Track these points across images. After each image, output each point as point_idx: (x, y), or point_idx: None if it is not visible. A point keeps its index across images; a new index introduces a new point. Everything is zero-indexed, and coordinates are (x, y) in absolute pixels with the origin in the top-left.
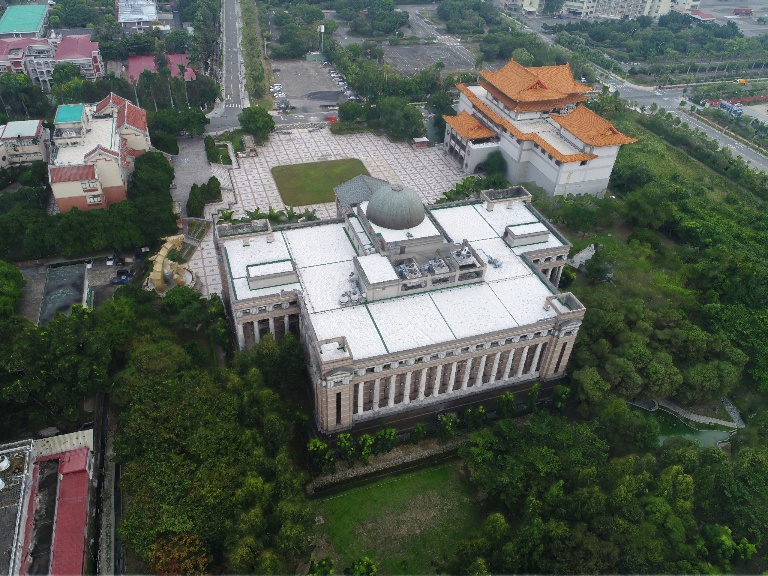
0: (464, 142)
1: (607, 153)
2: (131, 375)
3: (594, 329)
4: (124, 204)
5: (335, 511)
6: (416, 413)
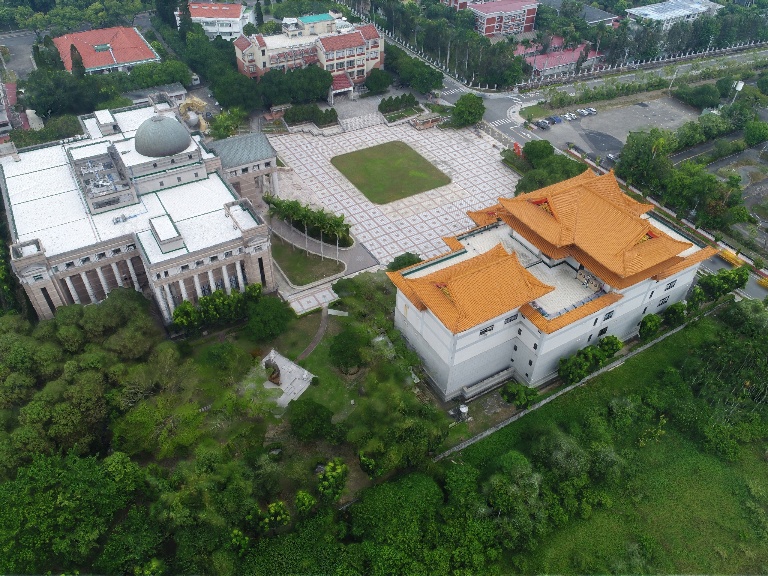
0: None
1: None
2: (54, 120)
3: None
4: None
5: None
6: None
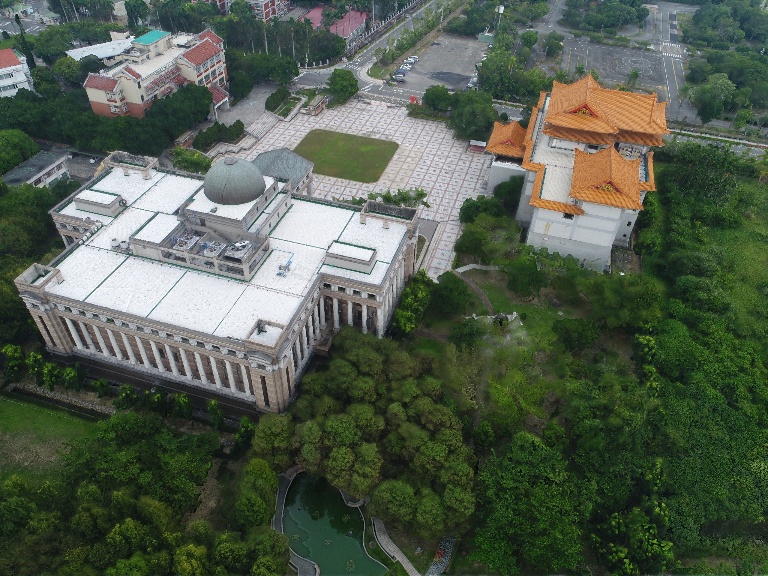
0: None
1: (605, 214)
2: None
3: (330, 383)
4: (124, 118)
5: (3, 412)
6: (133, 374)
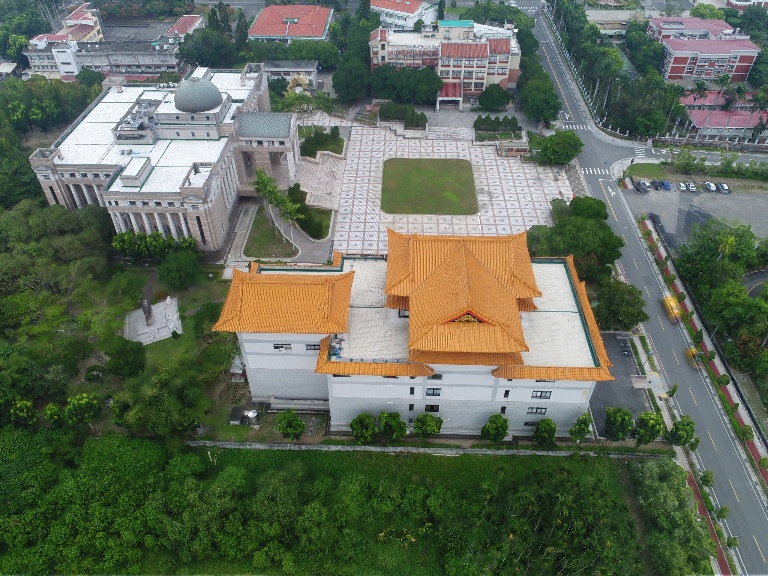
0: None
1: None
2: None
3: None
4: (355, 64)
5: None
6: None
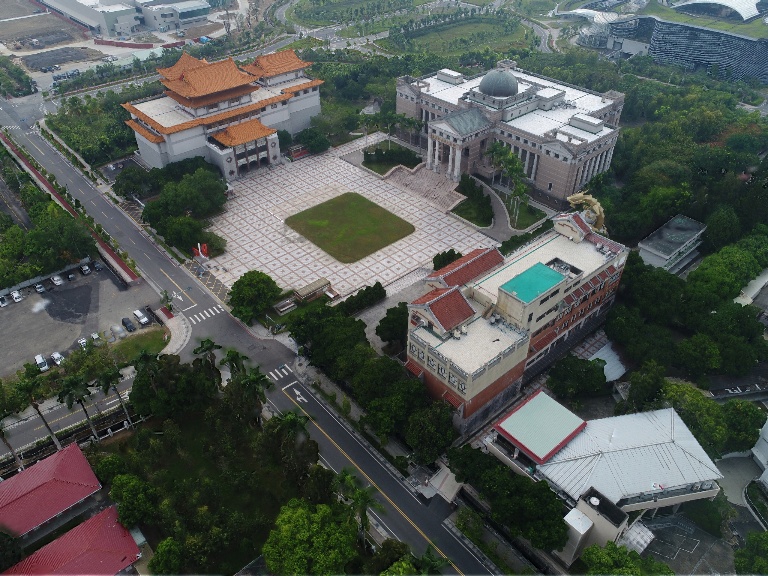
0: (262, 143)
1: None
2: None
3: None
4: None
5: None
6: None
